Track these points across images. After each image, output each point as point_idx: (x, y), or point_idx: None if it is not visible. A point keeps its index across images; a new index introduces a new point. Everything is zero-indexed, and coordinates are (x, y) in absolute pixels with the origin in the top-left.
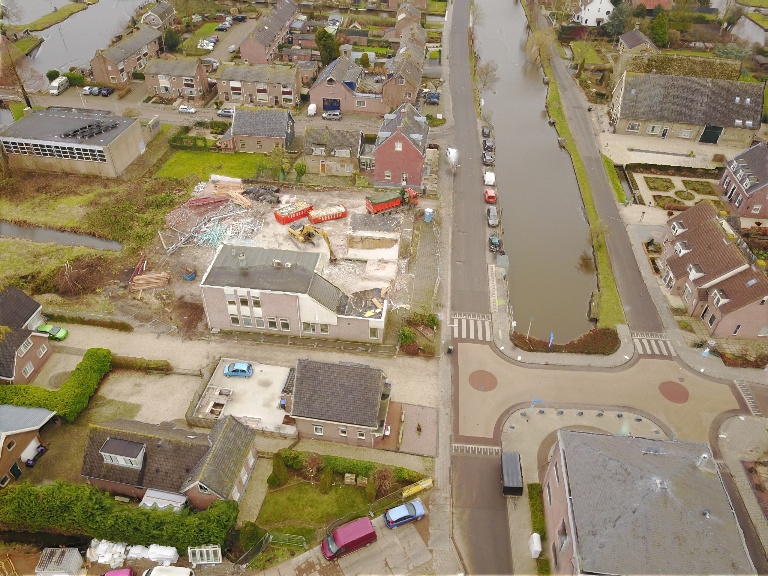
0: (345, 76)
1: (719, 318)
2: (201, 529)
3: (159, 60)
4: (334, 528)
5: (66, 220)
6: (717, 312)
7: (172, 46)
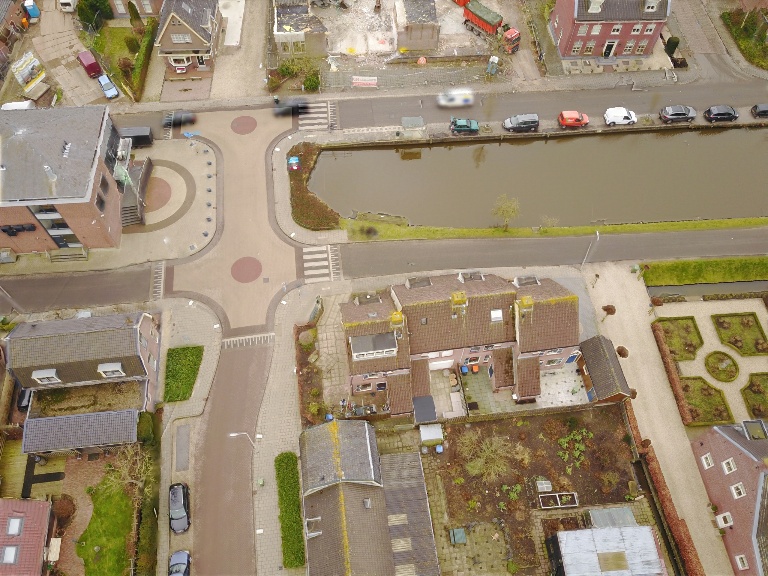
0: None
1: None
2: None
3: None
4: None
5: None
6: None
7: None
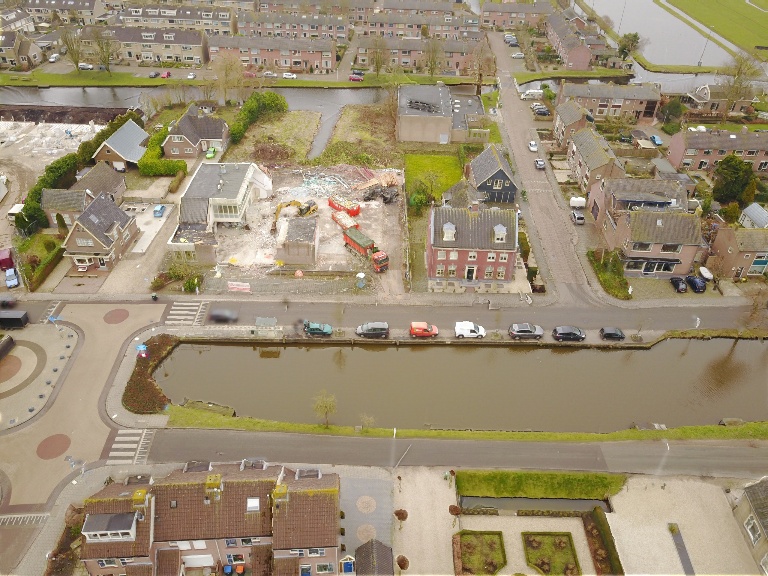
0: (630, 192)
1: None
2: (26, 203)
3: (572, 103)
4: None
5: (340, 138)
6: None
7: (666, 116)
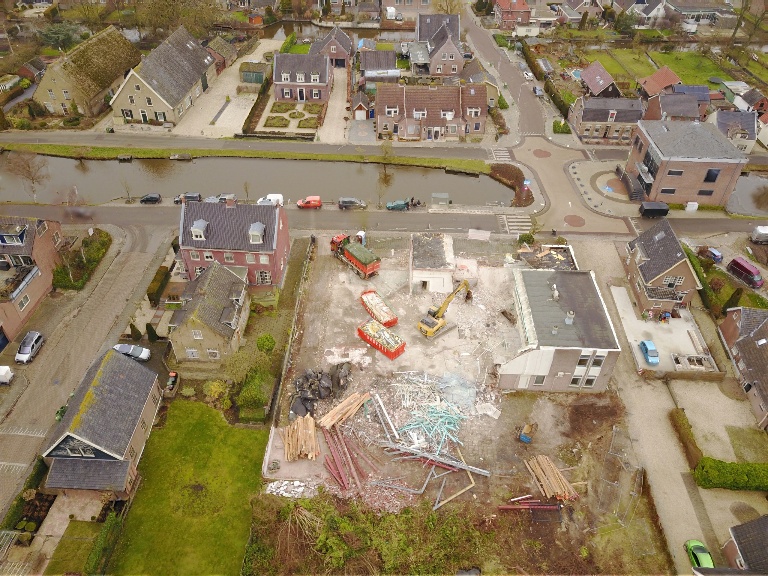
0: None
1: (484, 120)
2: None
3: None
4: (752, 273)
5: None
6: (480, 118)
7: None
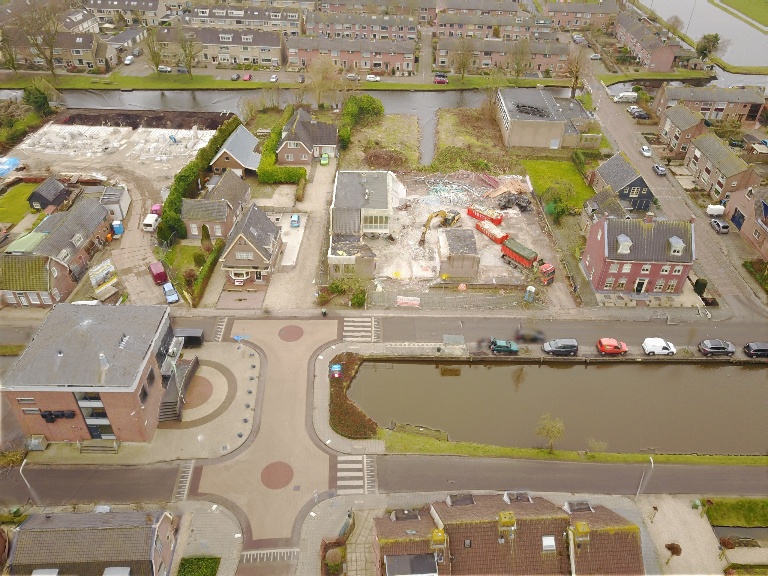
0: None
1: None
2: (164, 213)
3: (683, 107)
4: None
5: (446, 143)
6: None
7: None
